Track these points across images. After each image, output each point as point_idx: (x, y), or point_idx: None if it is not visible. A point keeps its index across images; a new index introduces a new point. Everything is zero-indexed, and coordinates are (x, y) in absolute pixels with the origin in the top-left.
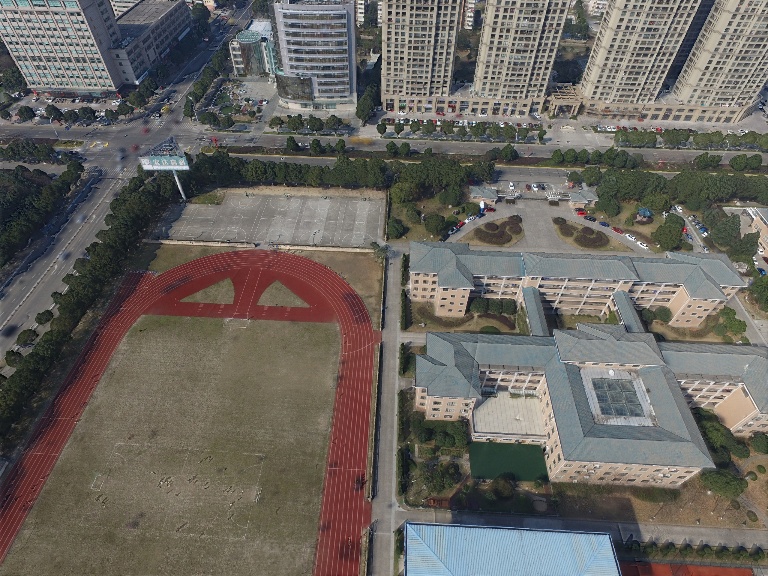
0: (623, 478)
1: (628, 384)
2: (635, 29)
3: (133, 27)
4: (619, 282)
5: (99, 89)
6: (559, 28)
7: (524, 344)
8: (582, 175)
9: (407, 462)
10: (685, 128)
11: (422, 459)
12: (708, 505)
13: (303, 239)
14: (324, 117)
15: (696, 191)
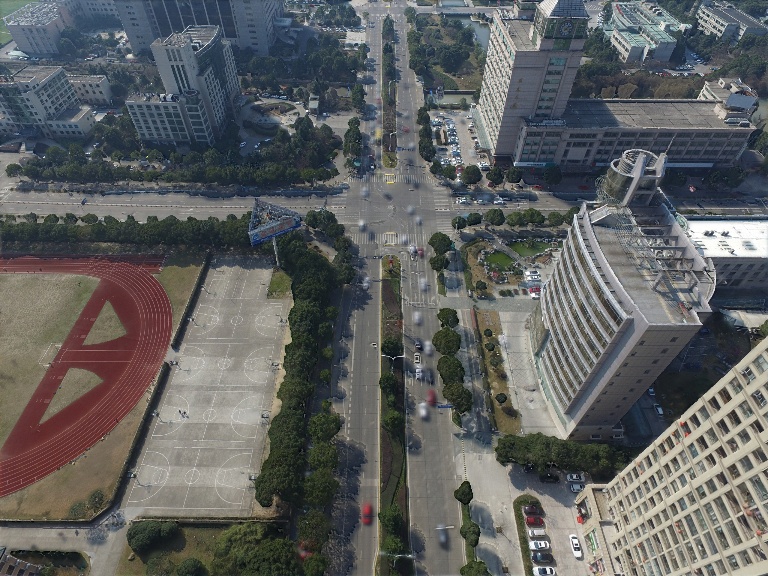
0: None
1: None
2: None
3: (604, 117)
4: None
5: (488, 144)
6: None
7: None
8: None
9: None
10: None
11: None
12: None
13: (173, 399)
14: (515, 385)
15: None
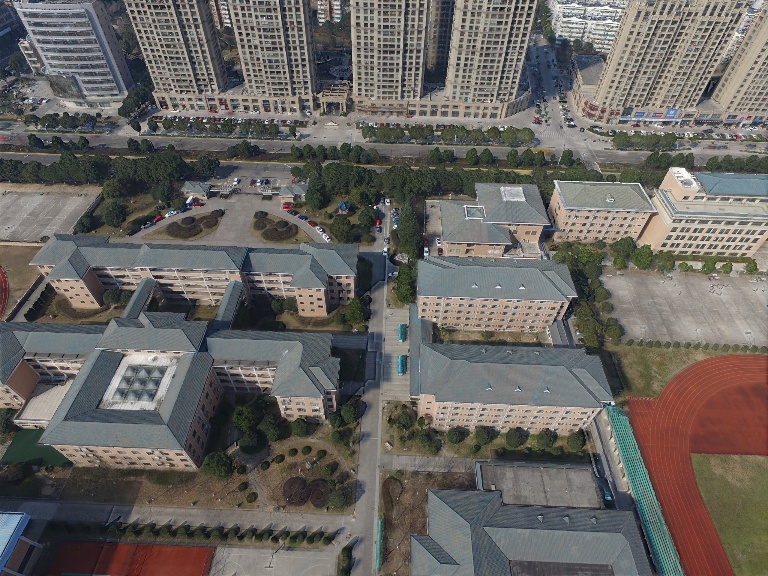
0: (136, 462)
1: (156, 370)
2: (374, 26)
3: None
4: (226, 272)
5: None
6: (301, 26)
7: (76, 332)
8: (303, 170)
9: None
10: (449, 124)
11: None
12: (216, 487)
13: None
14: (95, 115)
15: (398, 185)
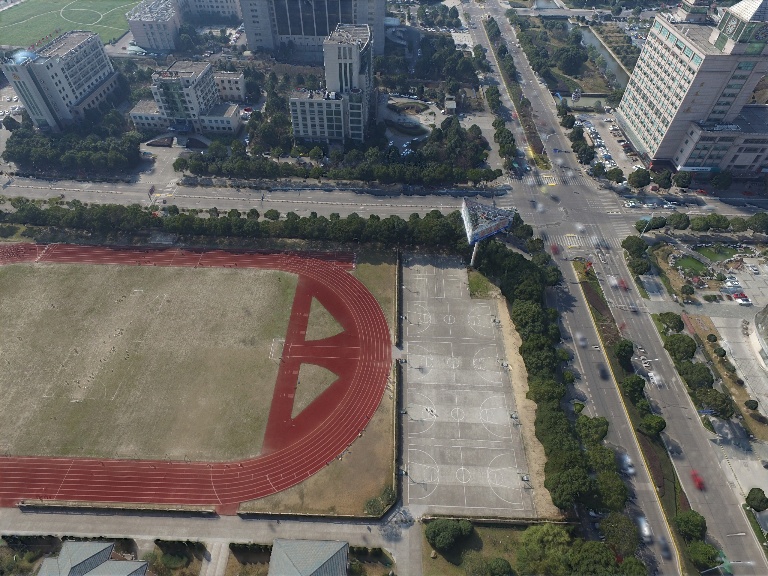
0: None
1: None
2: None
3: None
4: None
5: (644, 147)
6: None
7: None
8: None
9: (38, 548)
10: None
11: (36, 570)
12: None
13: (416, 397)
14: (755, 392)
15: None
